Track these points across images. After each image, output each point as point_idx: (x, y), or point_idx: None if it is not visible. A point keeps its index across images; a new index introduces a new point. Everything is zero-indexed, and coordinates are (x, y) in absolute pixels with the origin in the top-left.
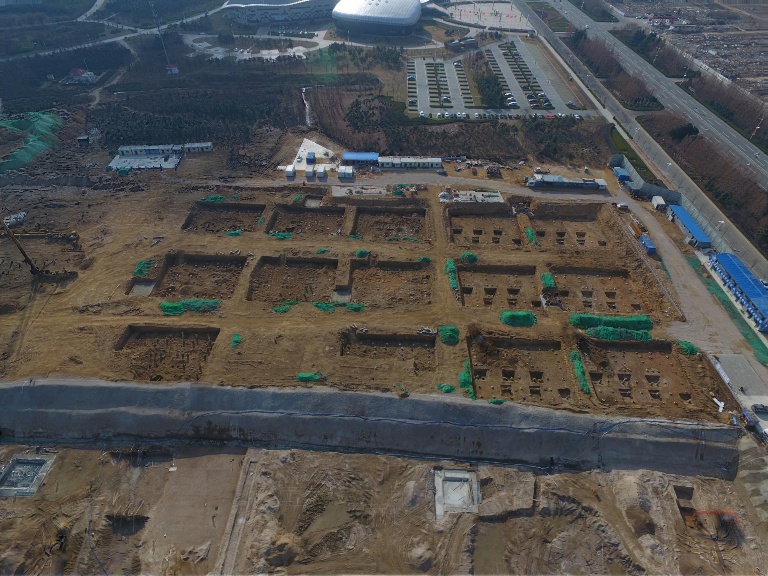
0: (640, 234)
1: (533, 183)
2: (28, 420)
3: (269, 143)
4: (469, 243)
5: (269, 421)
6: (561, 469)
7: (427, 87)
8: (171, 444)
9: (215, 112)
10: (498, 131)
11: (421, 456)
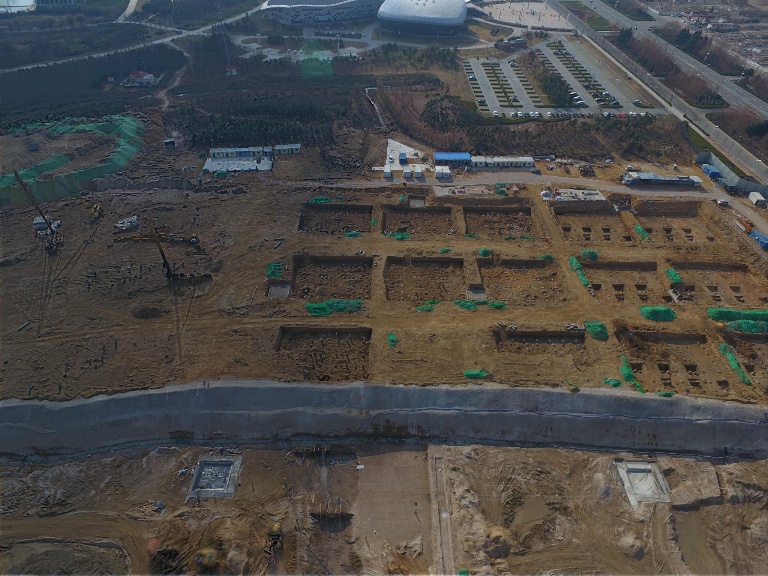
0: (751, 229)
1: (629, 181)
2: (207, 422)
3: (355, 144)
4: (583, 240)
5: (446, 418)
6: (736, 458)
7: (491, 87)
8: (350, 443)
9: (292, 114)
10: (580, 130)
11: (598, 449)
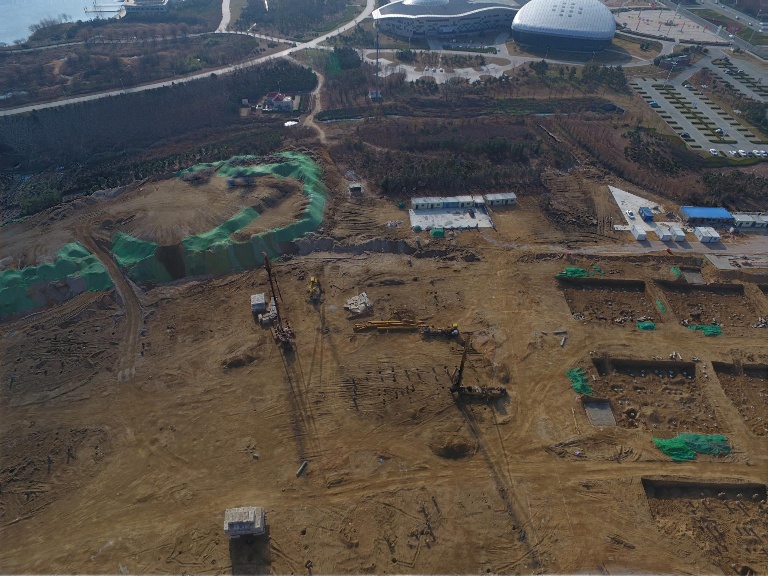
0: None
1: None
2: None
3: (573, 192)
4: None
5: None
6: None
7: (682, 116)
8: None
9: (480, 151)
10: None
11: None
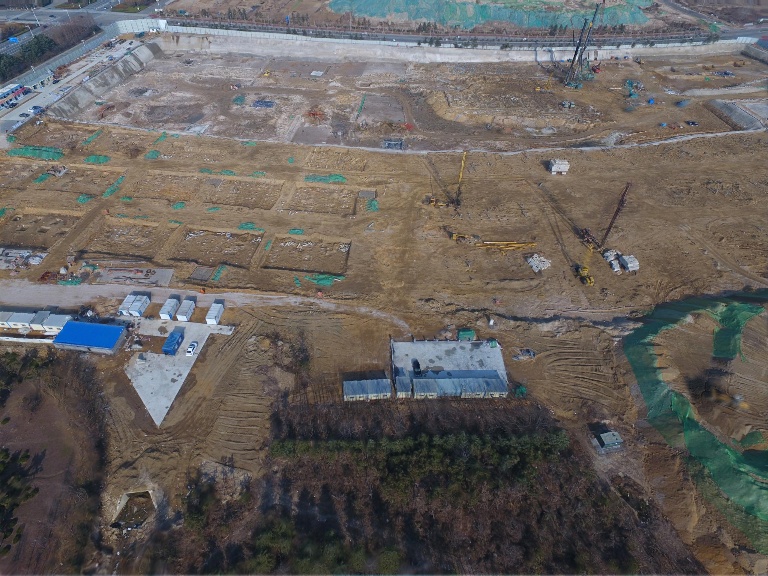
0: None
1: None
2: None
3: (236, 407)
4: None
5: None
6: None
7: None
8: None
9: None
10: None
11: None
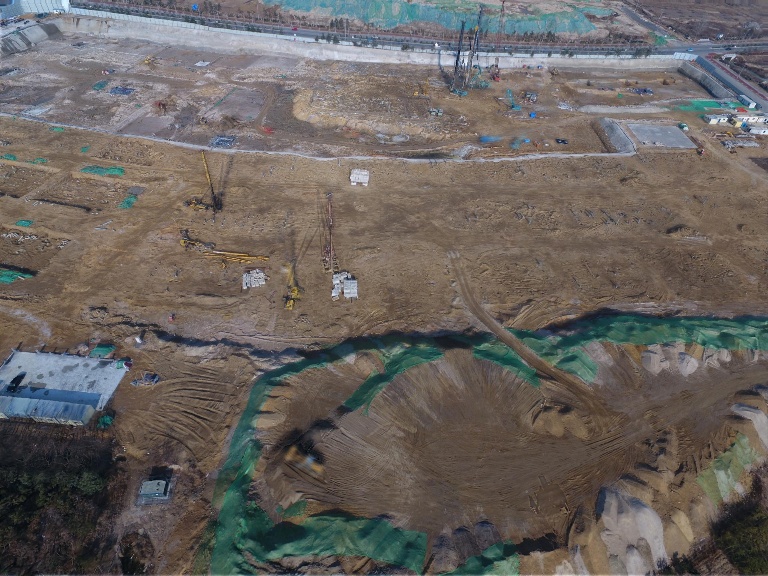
0: None
1: None
2: None
3: None
4: None
5: None
6: None
7: None
8: None
9: None
10: None
11: None
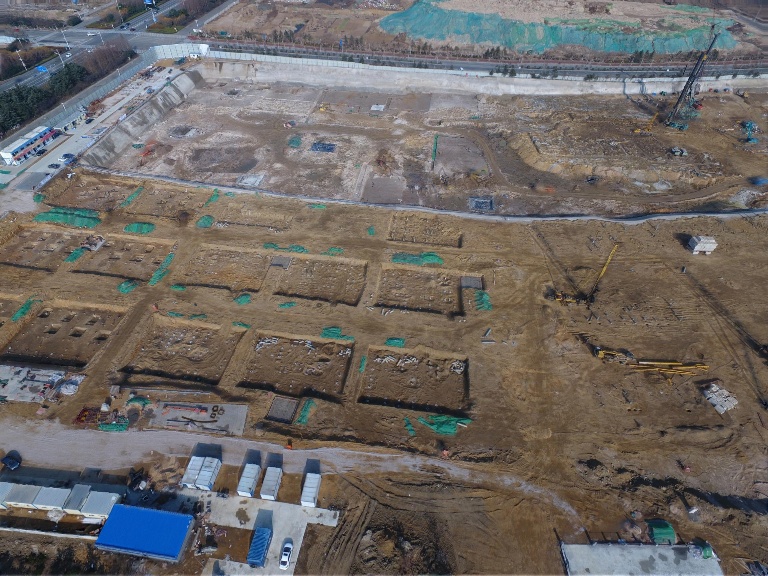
0: None
1: None
2: None
3: None
4: None
5: None
6: None
7: None
8: None
9: None
10: None
11: None
